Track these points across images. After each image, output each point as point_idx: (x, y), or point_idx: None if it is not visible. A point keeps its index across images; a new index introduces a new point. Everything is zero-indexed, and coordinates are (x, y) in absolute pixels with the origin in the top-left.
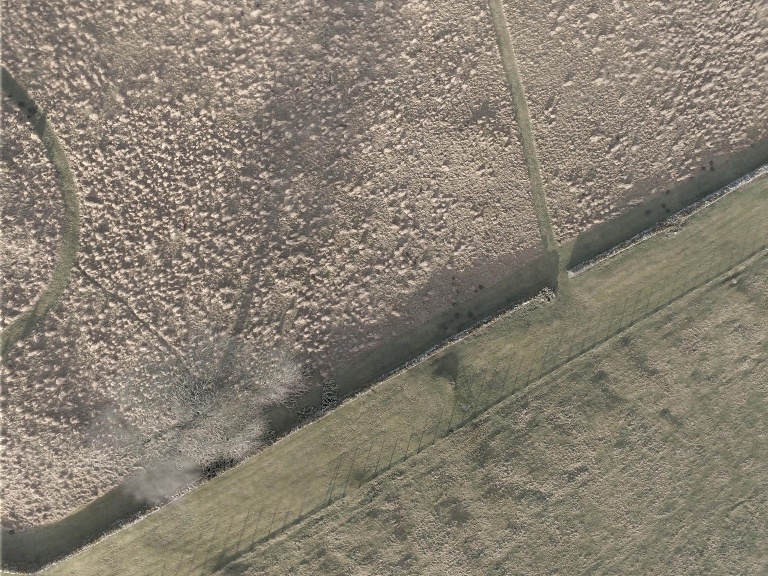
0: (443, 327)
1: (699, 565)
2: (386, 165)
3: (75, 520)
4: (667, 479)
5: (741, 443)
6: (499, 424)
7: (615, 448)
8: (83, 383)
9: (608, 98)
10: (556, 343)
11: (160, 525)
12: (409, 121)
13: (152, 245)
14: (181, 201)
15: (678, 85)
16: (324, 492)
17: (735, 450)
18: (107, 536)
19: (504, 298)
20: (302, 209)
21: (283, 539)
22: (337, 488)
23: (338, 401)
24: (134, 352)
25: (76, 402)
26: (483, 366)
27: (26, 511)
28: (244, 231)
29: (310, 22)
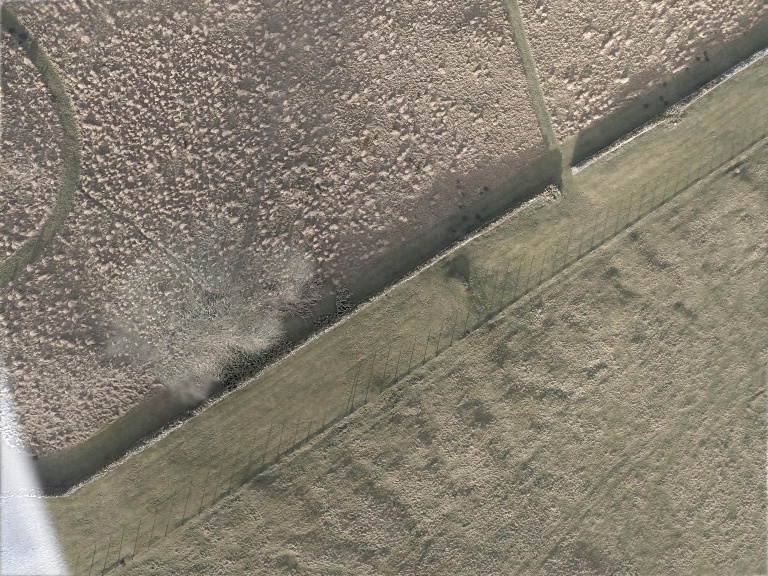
0: (451, 230)
1: (724, 457)
2: (382, 71)
3: (98, 441)
4: (686, 372)
5: (756, 333)
6: (515, 325)
7: (632, 343)
8: (95, 305)
9: None
10: (565, 241)
11: (184, 442)
12: (402, 26)
13: (154, 164)
14: (180, 119)
15: None
16: (346, 400)
17: (751, 340)
18: (132, 453)
19: (510, 199)
20: (302, 119)
21: (308, 449)
22: (358, 395)
23: (353, 307)
24: (144, 271)
25: (90, 324)
26: (494, 267)
27: (48, 436)
28: (245, 144)
29: None
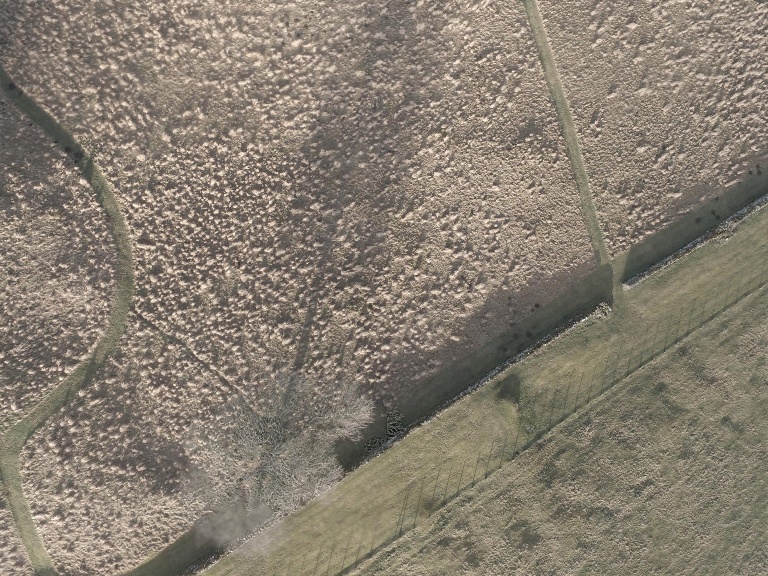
0: (502, 349)
1: (767, 571)
2: (436, 189)
3: (147, 569)
4: (732, 487)
5: None
6: (563, 443)
7: (679, 459)
8: (147, 429)
9: (652, 107)
10: (615, 357)
11: (233, 568)
12: (457, 143)
13: (207, 284)
14: (234, 238)
15: (720, 90)
16: (394, 524)
17: None
18: None
19: (561, 315)
20: (355, 238)
21: (356, 574)
22: (407, 519)
23: (404, 431)
24: (196, 394)
25: (141, 449)
26: (544, 385)
27: (97, 563)
28: (299, 264)
29: (352, 49)
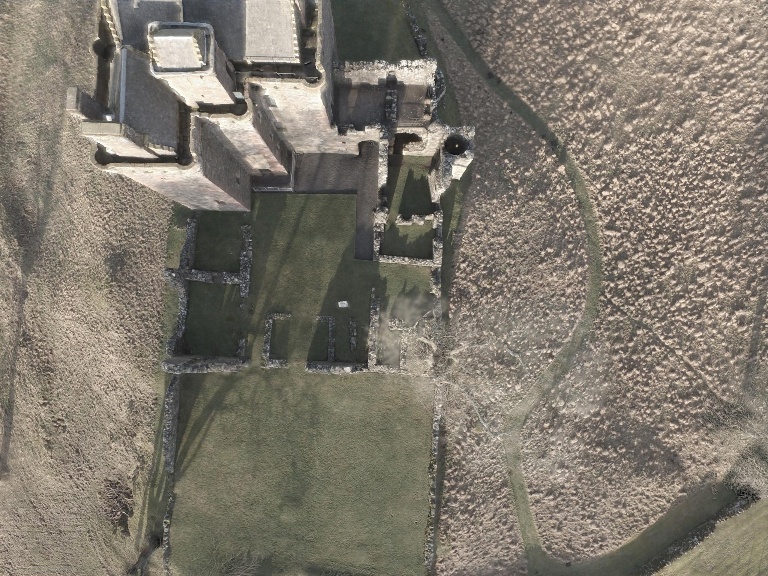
0: None
1: None
2: None
3: (628, 549)
4: None
5: None
6: None
7: None
8: (622, 411)
9: None
10: None
11: (704, 551)
12: None
13: (670, 271)
14: (690, 226)
15: None
16: None
17: None
18: None
19: None
20: None
21: None
22: None
23: None
24: (663, 378)
25: (618, 431)
26: None
27: (583, 542)
28: (751, 253)
29: None
